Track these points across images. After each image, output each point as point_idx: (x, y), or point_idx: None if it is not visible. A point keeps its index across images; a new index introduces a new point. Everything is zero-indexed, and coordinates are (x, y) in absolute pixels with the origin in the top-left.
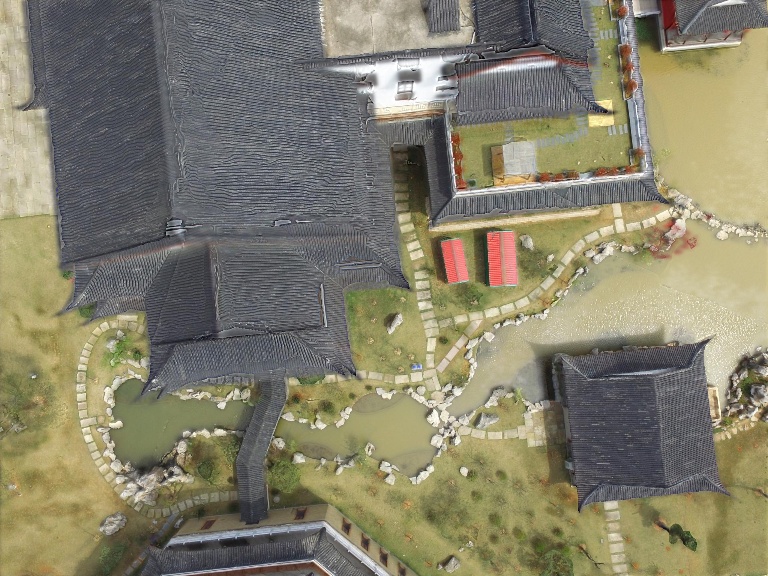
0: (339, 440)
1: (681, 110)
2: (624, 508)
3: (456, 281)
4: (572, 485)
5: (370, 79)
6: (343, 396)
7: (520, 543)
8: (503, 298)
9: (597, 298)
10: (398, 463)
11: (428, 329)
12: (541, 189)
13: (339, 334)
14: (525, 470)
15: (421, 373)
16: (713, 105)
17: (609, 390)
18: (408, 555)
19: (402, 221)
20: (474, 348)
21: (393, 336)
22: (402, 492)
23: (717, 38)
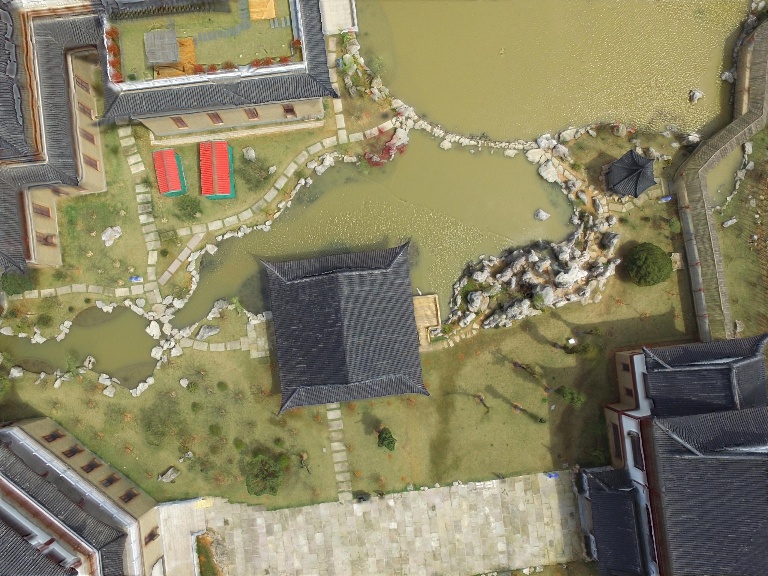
0: (60, 354)
1: (408, 22)
2: (347, 417)
3: (167, 191)
4: None
5: None
6: (63, 310)
7: (241, 453)
8: (227, 211)
9: (322, 209)
10: (119, 376)
11: (149, 242)
12: (210, 85)
13: (10, 233)
14: (248, 381)
15: (142, 286)
16: (451, 20)
17: (304, 292)
18: (129, 467)
19: (122, 134)
20: (197, 261)
21: (112, 249)
22: (123, 404)
23: None
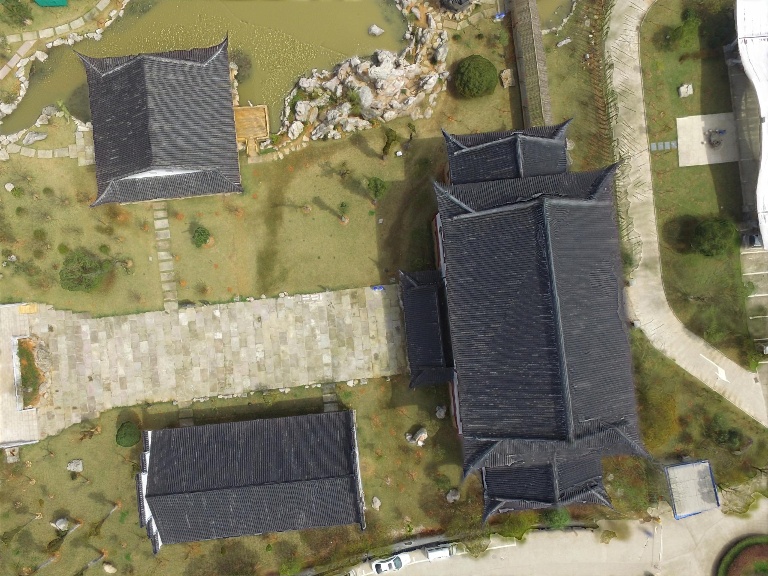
0: None
1: None
2: (174, 227)
3: None
4: (120, 202)
5: None
6: None
7: None
8: (58, 19)
9: (155, 21)
10: None
11: None
12: None
13: None
14: (75, 188)
15: None
16: None
17: (116, 82)
18: None
19: None
20: (26, 67)
21: None
22: None
23: None
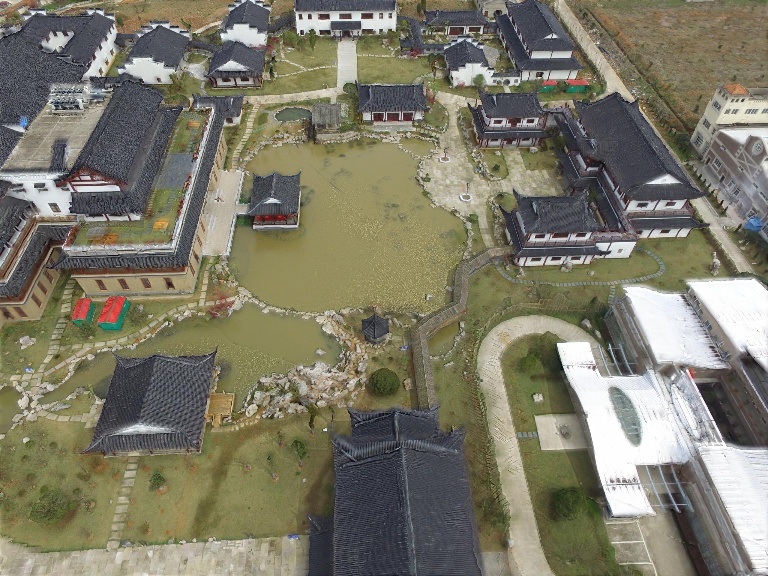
0: None
1: (260, 254)
2: (139, 477)
3: (76, 319)
4: (104, 455)
5: (31, 199)
6: None
7: None
8: (111, 337)
9: (174, 340)
10: None
11: (51, 350)
12: (119, 257)
13: None
14: (75, 444)
15: (32, 375)
16: None
17: None
18: None
19: (66, 293)
20: (77, 363)
21: (24, 351)
22: None
23: (283, 223)
